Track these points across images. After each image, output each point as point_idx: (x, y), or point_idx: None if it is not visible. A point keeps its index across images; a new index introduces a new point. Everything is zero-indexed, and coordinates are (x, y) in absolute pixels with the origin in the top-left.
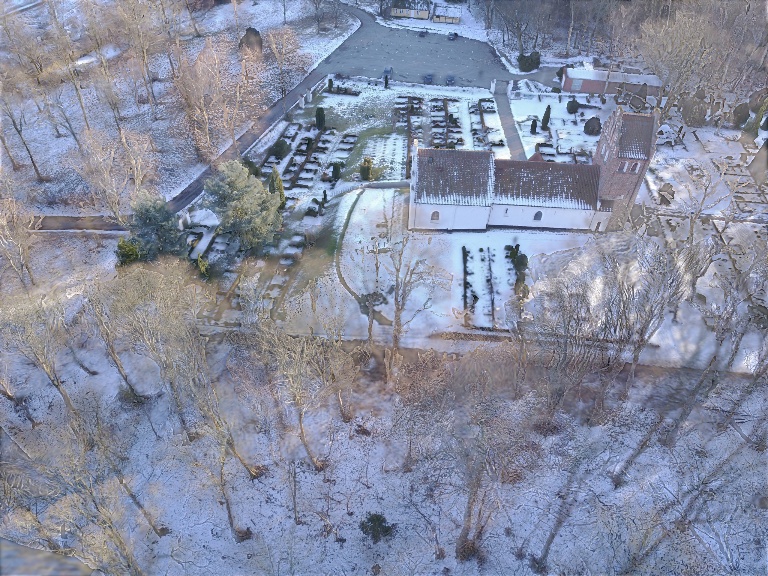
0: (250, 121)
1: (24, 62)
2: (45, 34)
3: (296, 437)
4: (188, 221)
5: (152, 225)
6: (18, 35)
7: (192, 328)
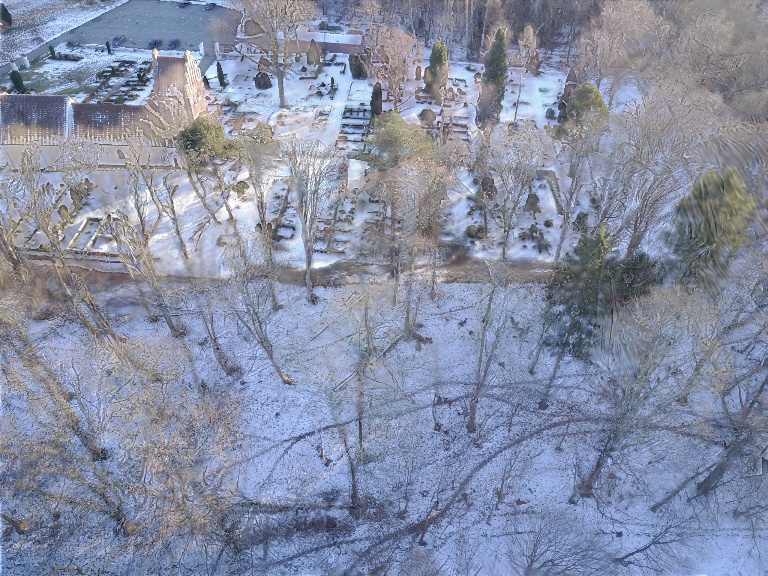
0: None
1: None
2: None
3: None
4: None
5: None
6: None
7: None
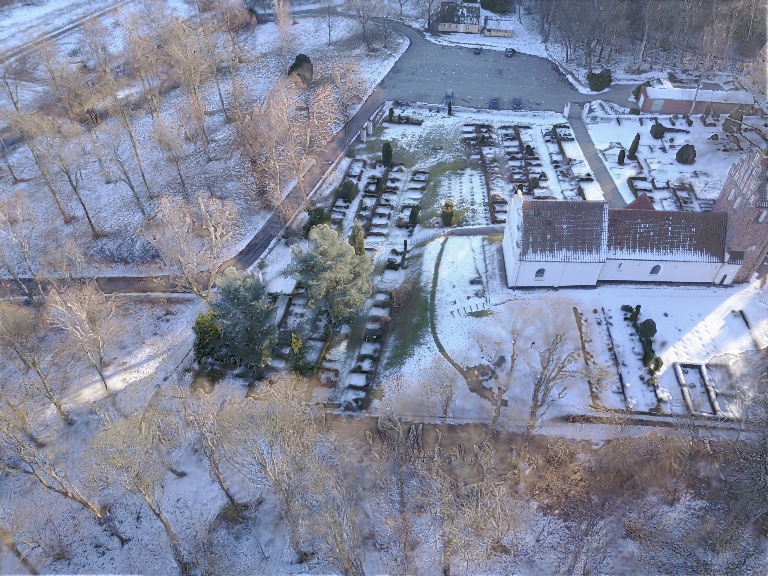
0: (310, 159)
1: (74, 109)
2: (96, 78)
3: None
4: (260, 280)
5: (241, 305)
6: (68, 81)
7: (340, 476)
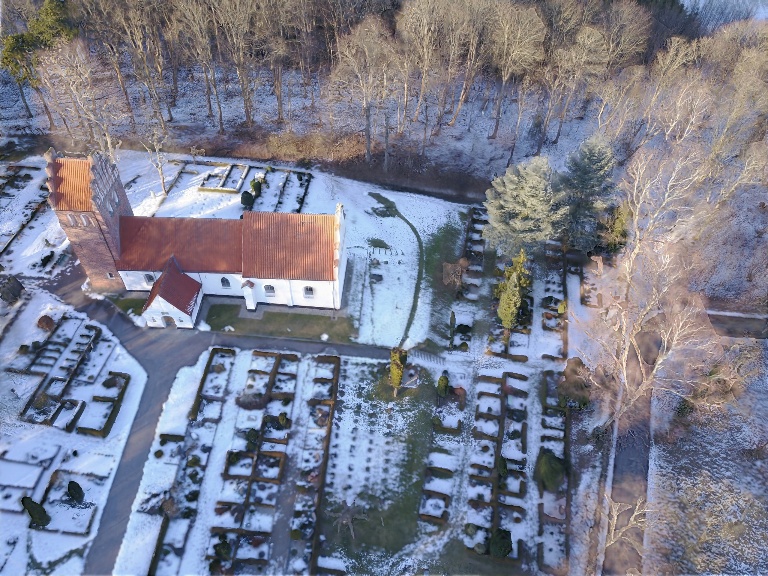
0: None
1: None
2: None
3: (430, 131)
4: None
5: None
6: None
7: None
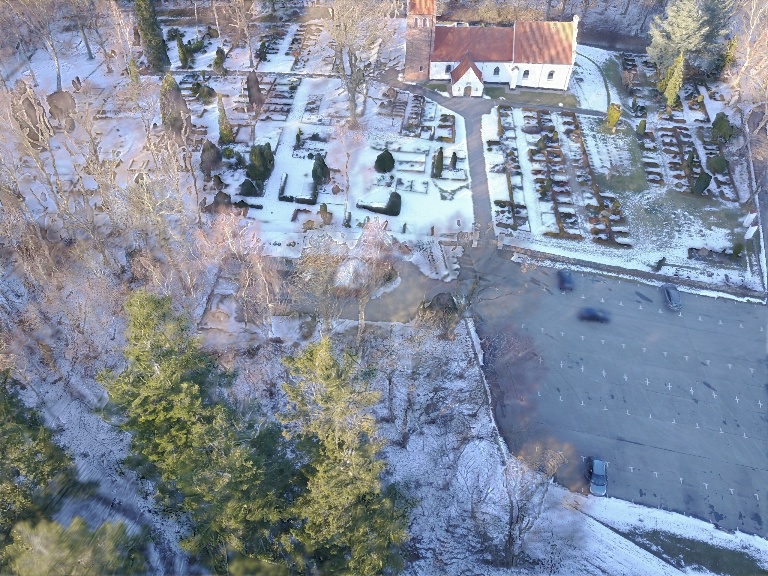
0: None
1: None
2: None
3: None
4: None
5: None
6: None
7: None
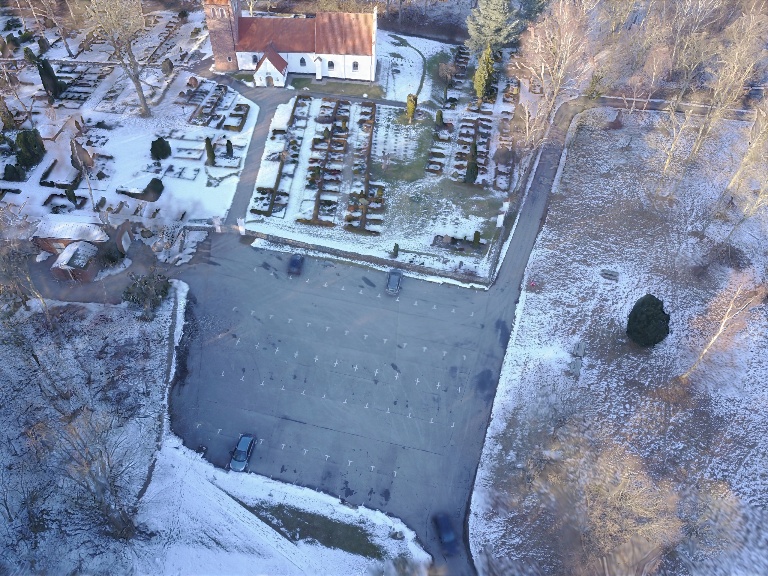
0: None
1: None
2: None
3: None
4: None
5: None
6: None
7: None
